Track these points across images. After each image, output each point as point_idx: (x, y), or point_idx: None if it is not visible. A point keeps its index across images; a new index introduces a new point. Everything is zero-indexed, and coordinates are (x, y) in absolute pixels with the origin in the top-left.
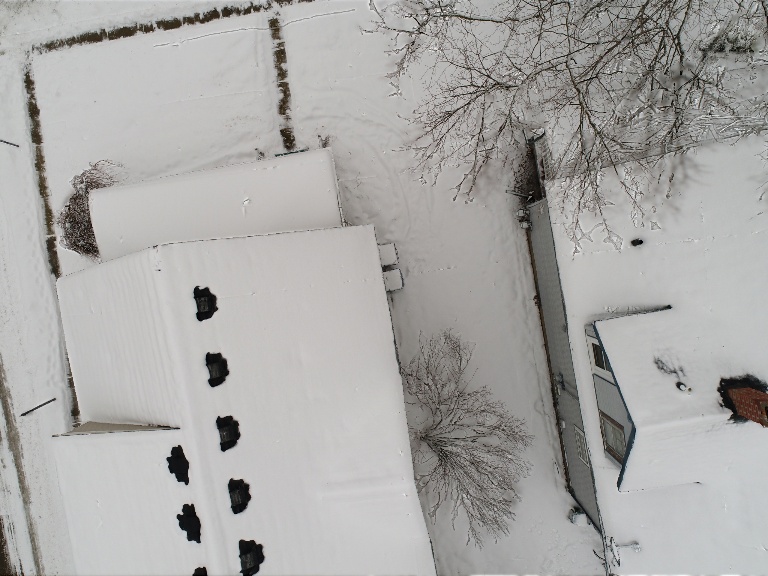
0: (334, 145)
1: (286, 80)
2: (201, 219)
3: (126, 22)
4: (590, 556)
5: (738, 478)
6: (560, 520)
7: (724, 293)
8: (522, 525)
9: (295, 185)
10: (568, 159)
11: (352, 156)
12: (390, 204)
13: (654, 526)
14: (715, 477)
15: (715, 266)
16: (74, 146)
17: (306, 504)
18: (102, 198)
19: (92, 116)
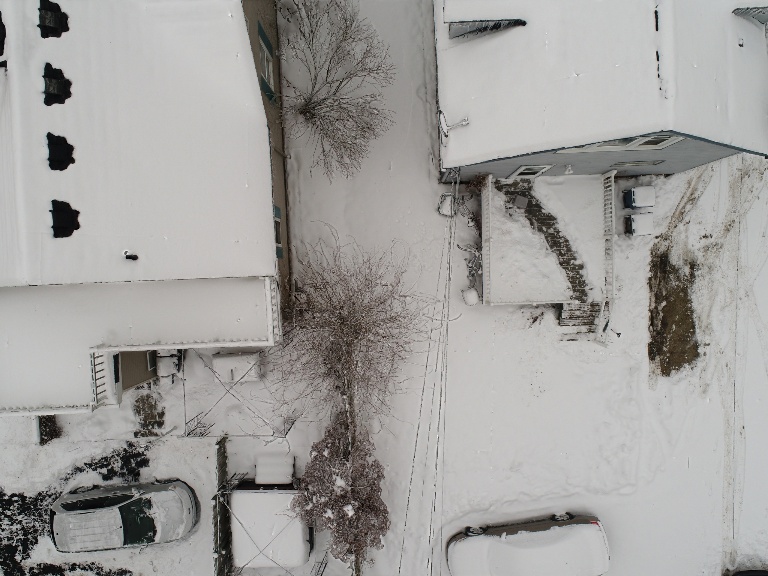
0: None
1: None
2: None
3: None
4: (454, 252)
5: (560, 5)
6: (428, 212)
7: None
8: (390, 215)
9: None
10: None
11: None
12: None
13: (483, 93)
14: (538, 5)
15: None
16: None
17: (127, 7)
18: None
19: None
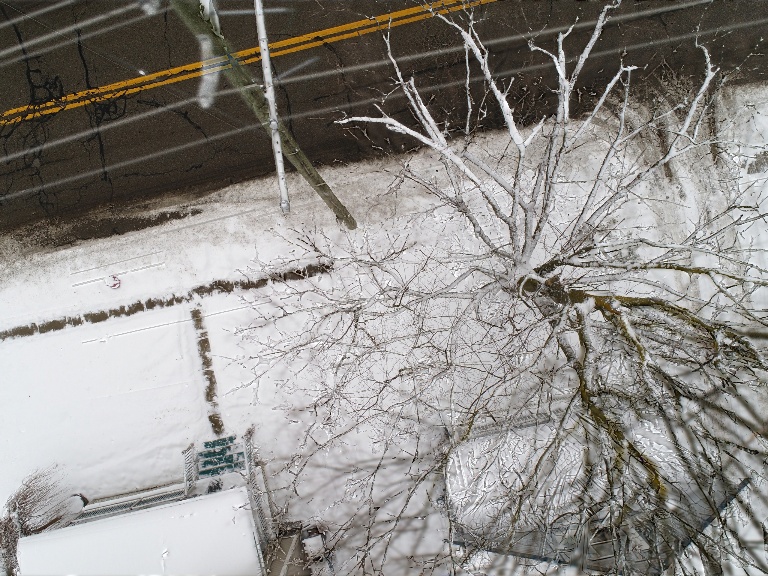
0: (260, 432)
1: (211, 368)
2: (123, 575)
3: (55, 317)
4: None
5: None
6: None
7: None
8: None
9: (211, 533)
10: (481, 450)
11: (278, 442)
12: (318, 485)
13: None
14: None
15: None
16: (12, 439)
17: None
18: (29, 553)
19: (27, 410)
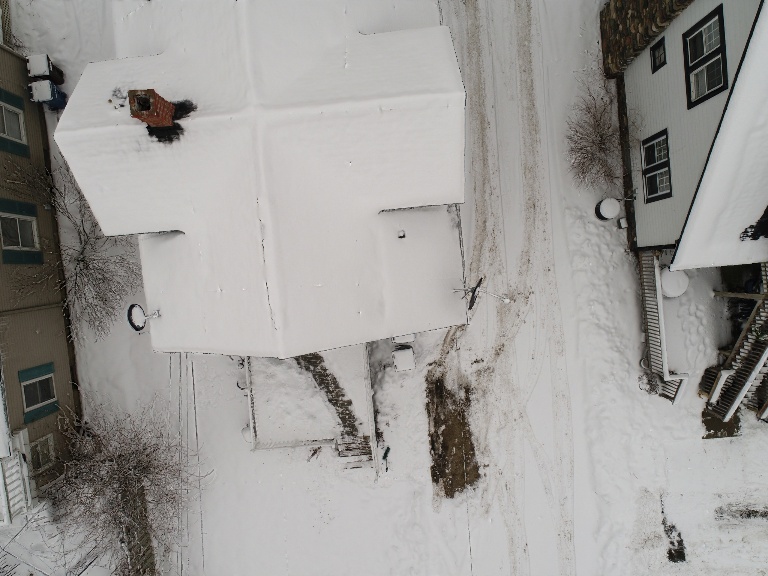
0: None
1: None
2: None
3: None
4: (236, 388)
5: (205, 221)
6: None
7: (190, 29)
8: None
9: None
10: None
11: None
12: (61, 23)
13: (167, 289)
14: (186, 221)
15: (186, 3)
16: None
17: None
18: None
19: None
